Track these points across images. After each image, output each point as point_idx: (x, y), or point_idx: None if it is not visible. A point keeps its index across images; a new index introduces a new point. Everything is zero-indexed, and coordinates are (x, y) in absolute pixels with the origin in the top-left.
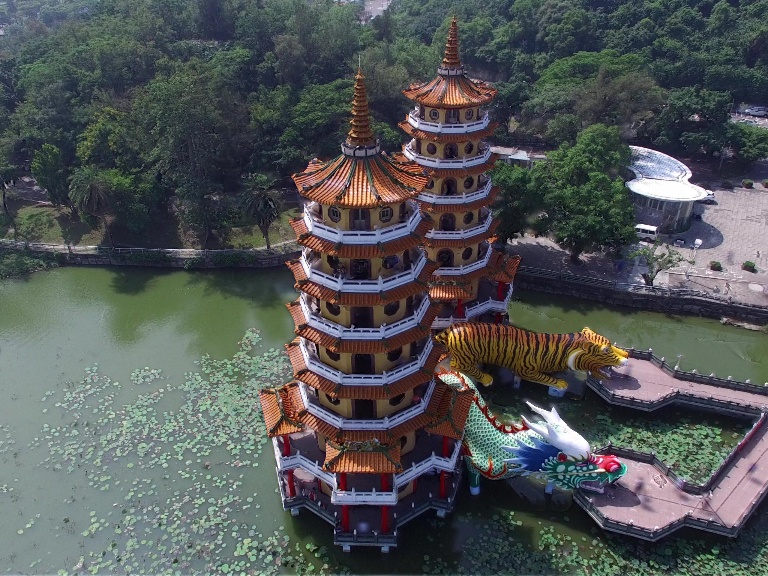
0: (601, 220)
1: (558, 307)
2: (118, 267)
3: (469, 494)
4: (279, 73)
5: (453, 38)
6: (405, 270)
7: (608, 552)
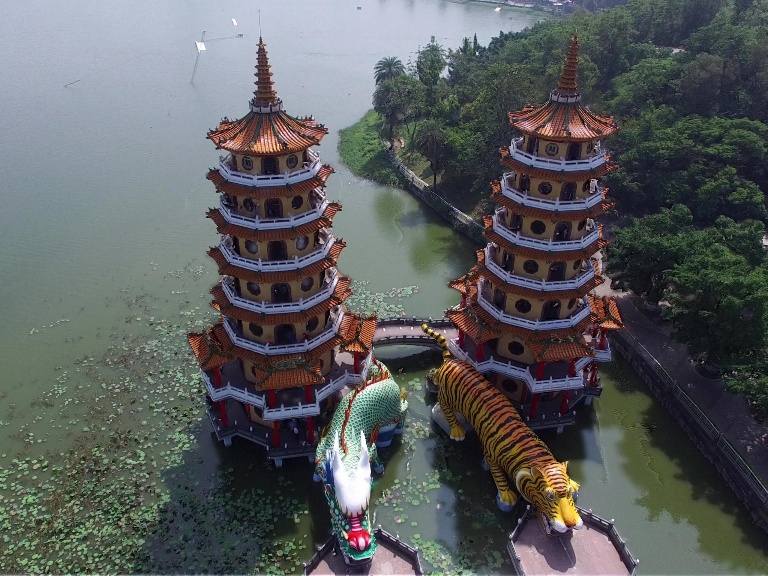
0: None
1: (678, 467)
2: (426, 206)
3: (312, 475)
4: (681, 93)
5: (568, 59)
6: (252, 217)
7: None
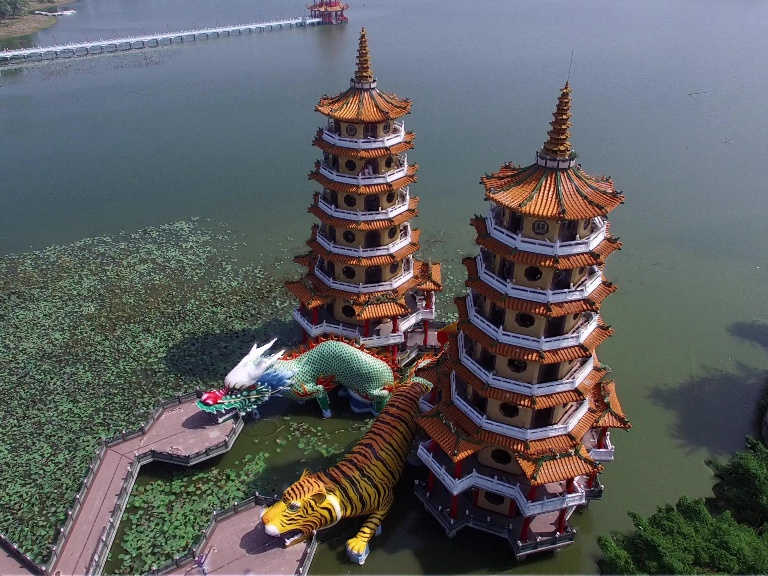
0: None
1: None
2: None
3: None
4: None
5: None
6: None
7: None
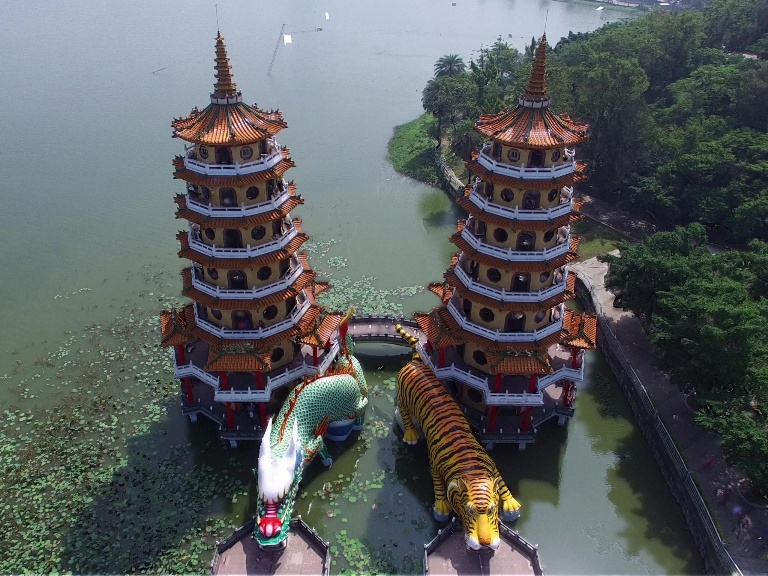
0: (759, 443)
1: (640, 501)
2: (459, 207)
3: None
4: None
5: (535, 62)
6: (206, 204)
7: (208, 574)
